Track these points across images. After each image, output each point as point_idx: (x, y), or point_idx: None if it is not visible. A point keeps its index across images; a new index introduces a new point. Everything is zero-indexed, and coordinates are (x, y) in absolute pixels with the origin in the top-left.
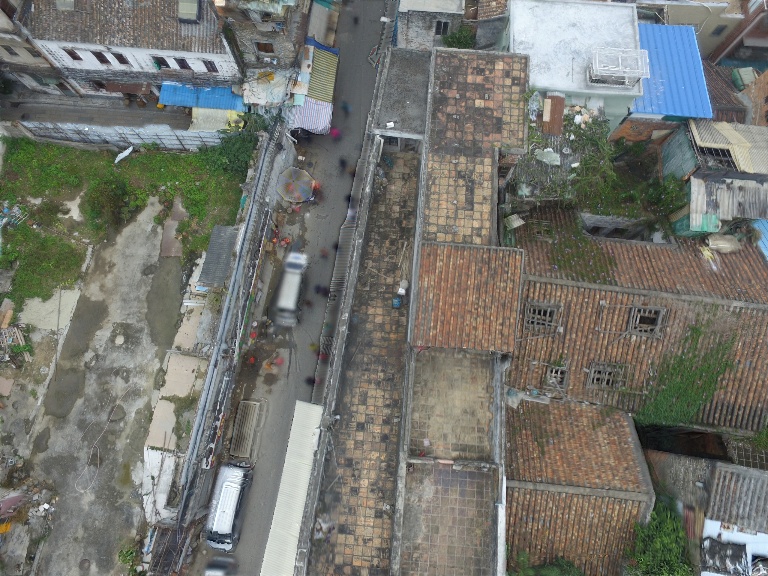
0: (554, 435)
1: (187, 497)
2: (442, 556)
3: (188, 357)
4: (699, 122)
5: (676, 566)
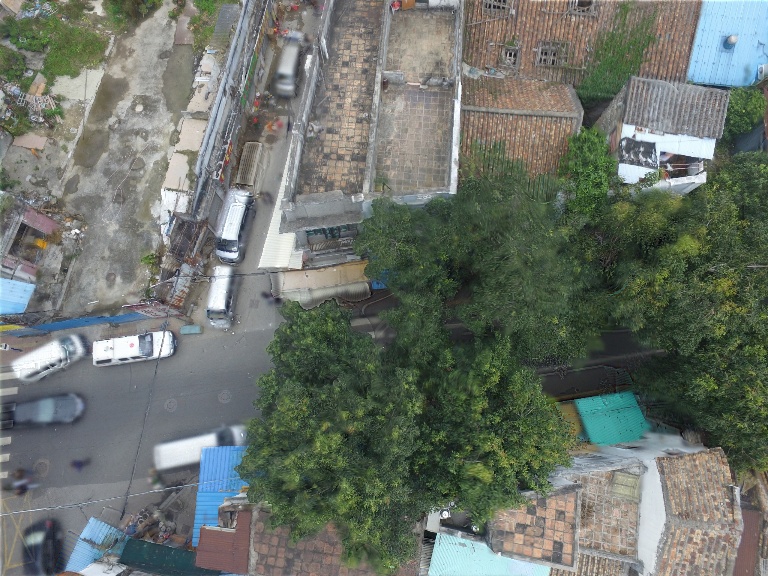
0: (506, 92)
1: (200, 193)
2: (410, 148)
3: (199, 121)
4: None
5: (600, 166)
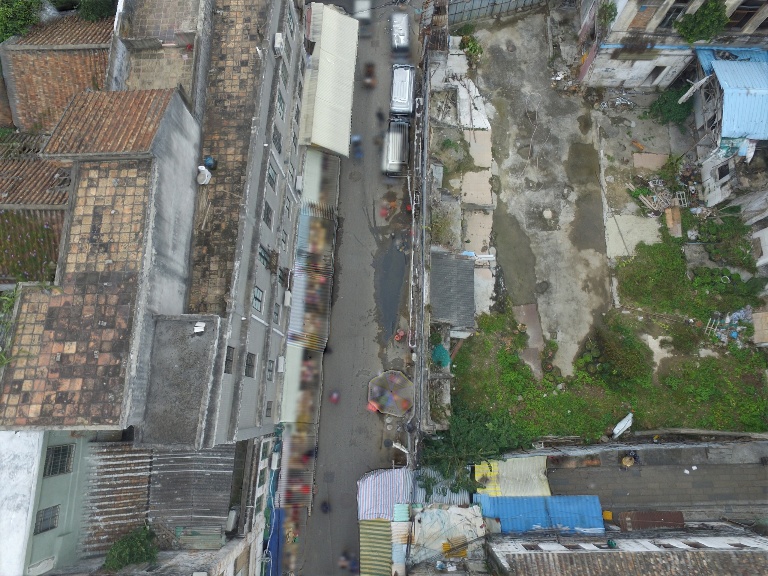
0: None
1: None
2: None
3: None
4: None
5: None
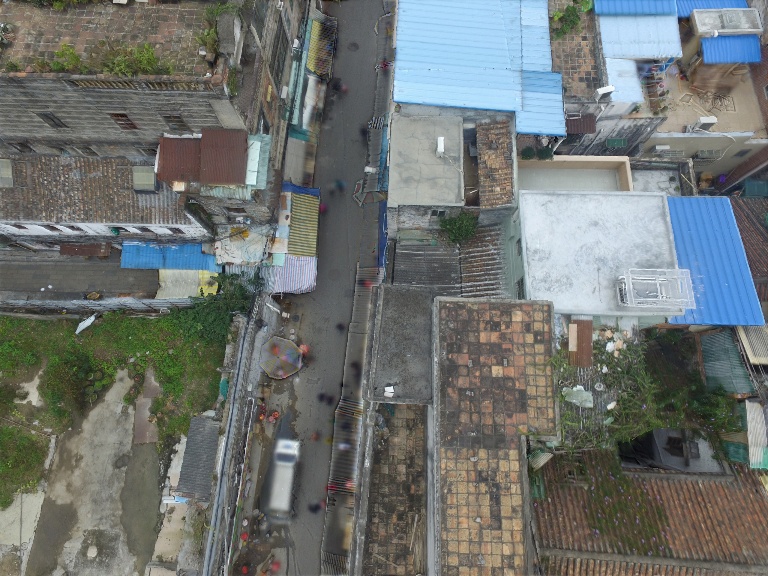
0: None
1: None
2: None
3: None
4: (748, 326)
5: None
